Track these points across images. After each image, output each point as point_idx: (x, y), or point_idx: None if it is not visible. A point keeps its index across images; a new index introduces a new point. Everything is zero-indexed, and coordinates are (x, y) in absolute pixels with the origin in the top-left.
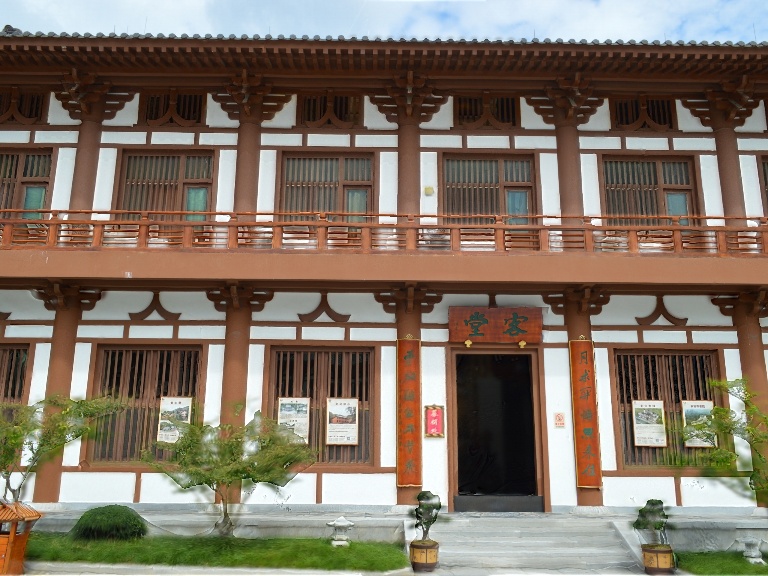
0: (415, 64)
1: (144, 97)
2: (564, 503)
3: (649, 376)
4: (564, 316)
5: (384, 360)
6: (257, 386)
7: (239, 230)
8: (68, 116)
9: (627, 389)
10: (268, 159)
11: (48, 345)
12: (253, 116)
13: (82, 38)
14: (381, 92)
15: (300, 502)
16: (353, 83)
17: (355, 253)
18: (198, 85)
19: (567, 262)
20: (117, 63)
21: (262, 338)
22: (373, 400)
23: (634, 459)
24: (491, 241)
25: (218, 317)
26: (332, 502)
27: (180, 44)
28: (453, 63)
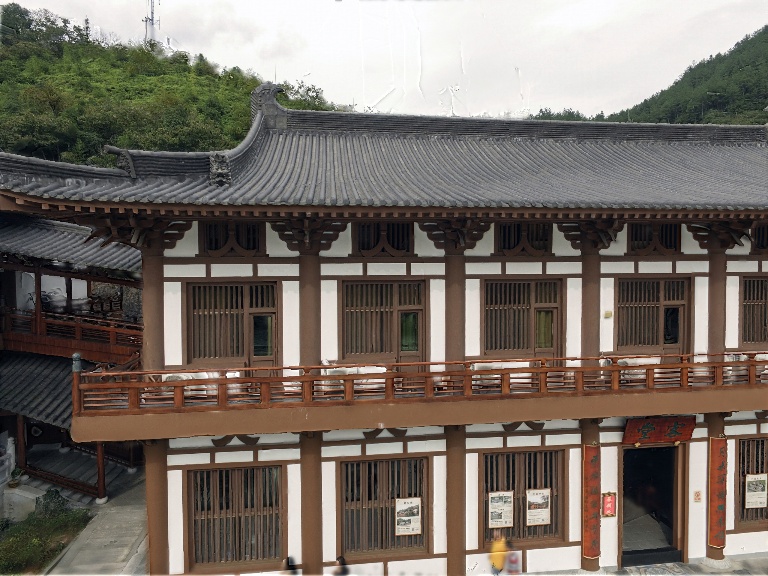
0: None
1: (355, 226)
2: (697, 556)
3: (759, 456)
4: (704, 414)
5: (572, 460)
6: (474, 487)
7: (472, 378)
8: (286, 247)
9: (742, 466)
10: (473, 288)
11: (298, 466)
12: (460, 248)
13: (328, 206)
14: None
15: (511, 573)
16: None
17: (571, 396)
18: None
19: (736, 395)
20: None
21: (476, 448)
22: (561, 489)
23: (743, 517)
24: (677, 378)
25: (438, 431)
26: (534, 570)
27: (424, 210)
28: None
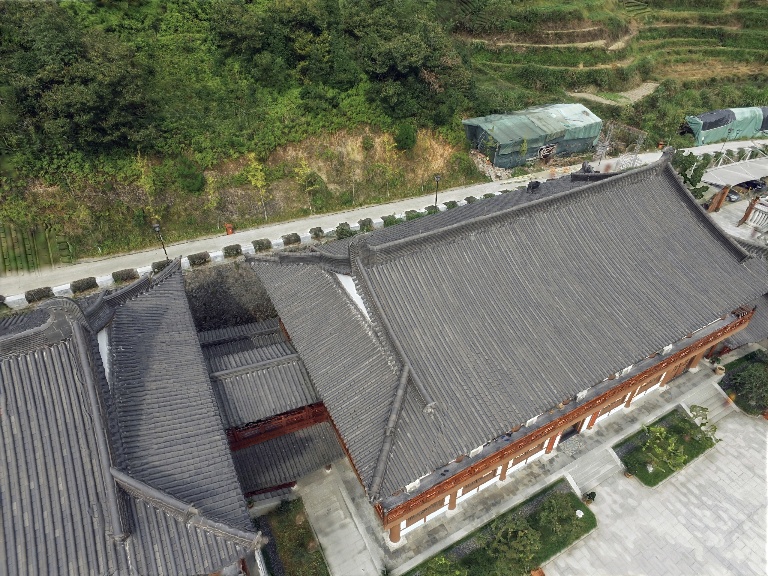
0: None
1: None
2: None
3: None
4: None
5: None
6: None
7: None
8: None
9: None
10: None
11: None
12: None
13: None
14: None
15: None
16: None
17: None
18: None
19: None
20: None
21: None
22: None
23: None
24: None
25: None
26: None
27: None
28: None
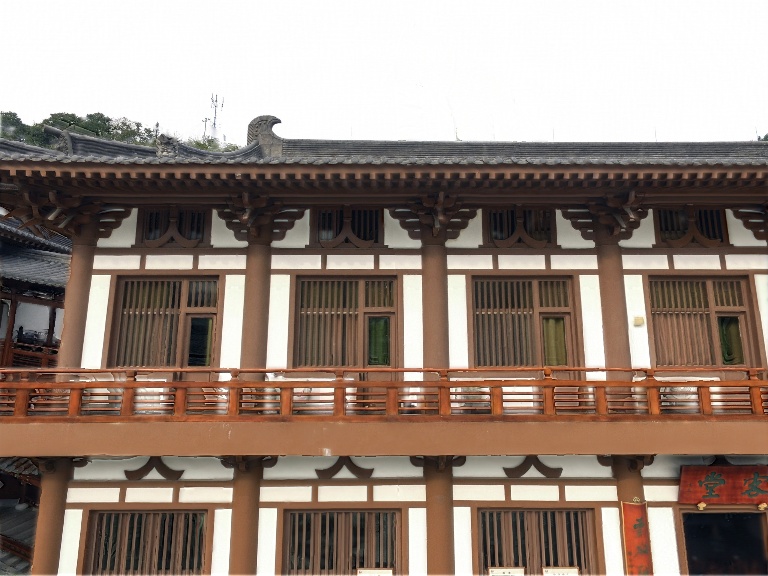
0: (644, 185)
1: (315, 214)
2: None
3: None
4: None
5: (606, 524)
6: (466, 558)
7: (451, 391)
8: (233, 237)
9: None
10: (457, 285)
11: (228, 512)
12: (439, 237)
13: (260, 164)
14: (577, 206)
15: None
16: (553, 200)
17: (591, 420)
18: (378, 203)
19: None
20: (295, 187)
21: (467, 499)
22: (595, 570)
23: None
24: (746, 401)
25: (415, 473)
26: None
27: (377, 169)
28: (689, 184)
